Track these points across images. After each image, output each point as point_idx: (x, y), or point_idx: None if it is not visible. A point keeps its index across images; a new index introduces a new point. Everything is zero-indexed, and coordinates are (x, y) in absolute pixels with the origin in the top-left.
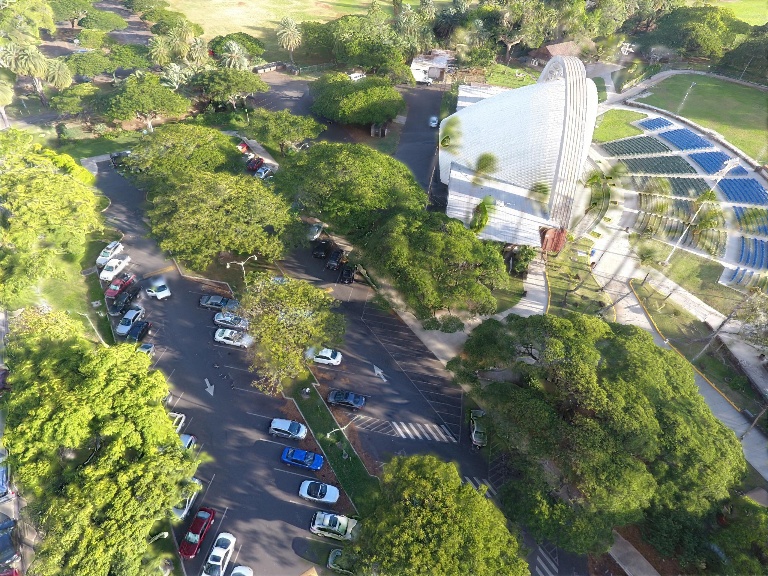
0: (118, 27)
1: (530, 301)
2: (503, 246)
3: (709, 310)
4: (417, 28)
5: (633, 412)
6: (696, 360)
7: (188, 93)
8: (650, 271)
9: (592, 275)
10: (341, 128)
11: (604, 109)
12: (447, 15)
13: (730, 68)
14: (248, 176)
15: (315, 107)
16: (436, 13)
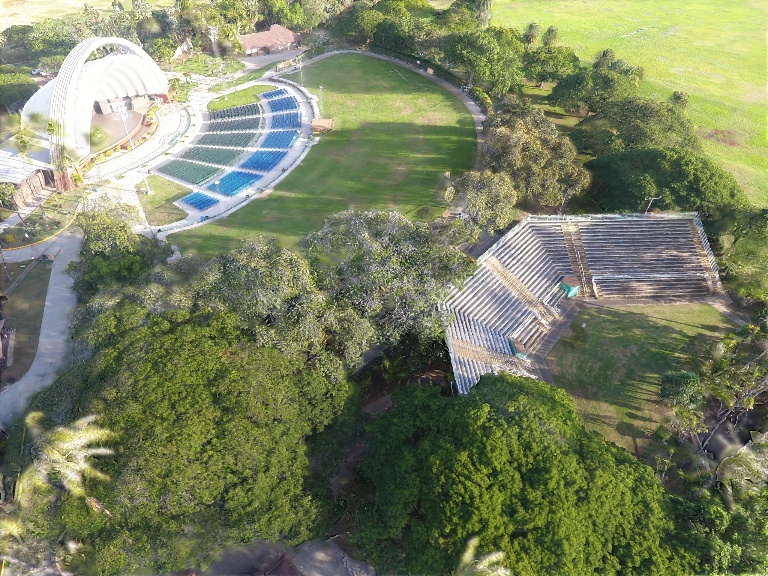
0: None
1: (3, 224)
2: None
3: None
4: (110, 26)
5: None
6: None
7: None
8: (131, 199)
9: (78, 204)
10: None
11: (250, 85)
12: (164, 14)
13: (376, 46)
14: None
15: None
16: (156, 13)
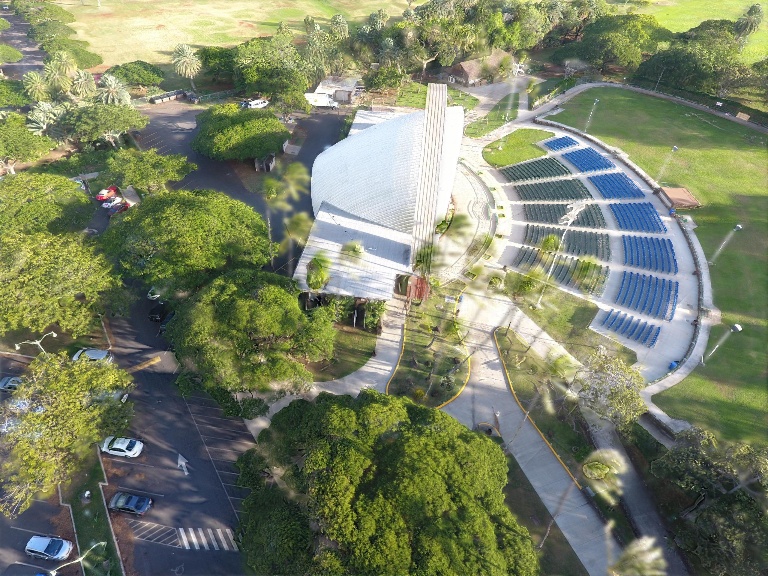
0: (10, 60)
1: (379, 361)
2: (353, 300)
3: (572, 362)
4: (322, 50)
5: (380, 543)
6: (545, 426)
7: (58, 133)
8: (519, 317)
9: (455, 325)
10: (226, 163)
11: (512, 129)
12: (362, 33)
13: (645, 80)
14: (70, 235)
15: (193, 143)
16: (351, 32)
